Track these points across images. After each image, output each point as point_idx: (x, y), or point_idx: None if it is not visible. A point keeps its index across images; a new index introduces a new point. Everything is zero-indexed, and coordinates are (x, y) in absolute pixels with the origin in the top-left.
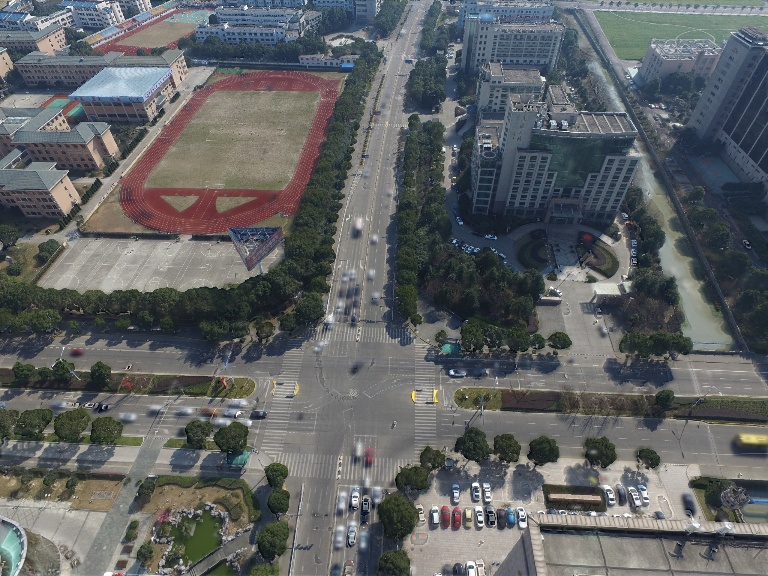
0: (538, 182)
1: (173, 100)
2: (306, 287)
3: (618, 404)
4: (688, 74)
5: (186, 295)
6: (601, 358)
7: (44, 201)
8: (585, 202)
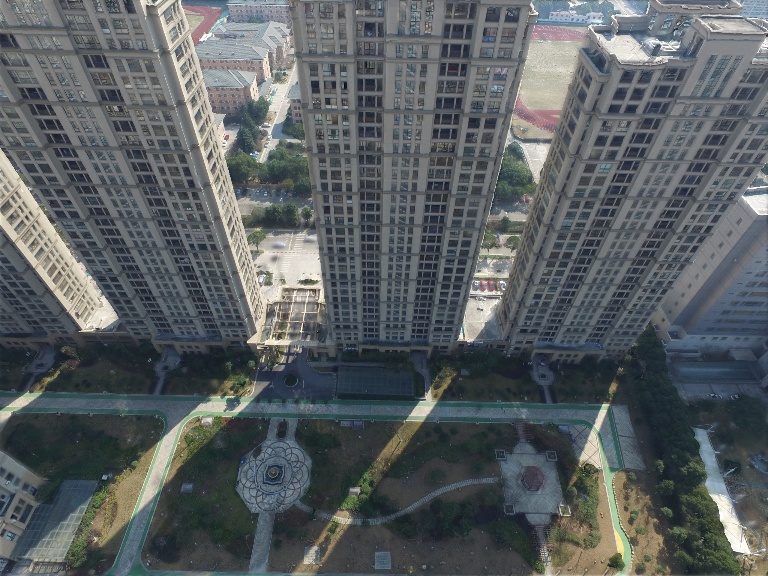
0: None
1: None
2: None
3: None
4: None
5: None
6: None
7: None
8: None
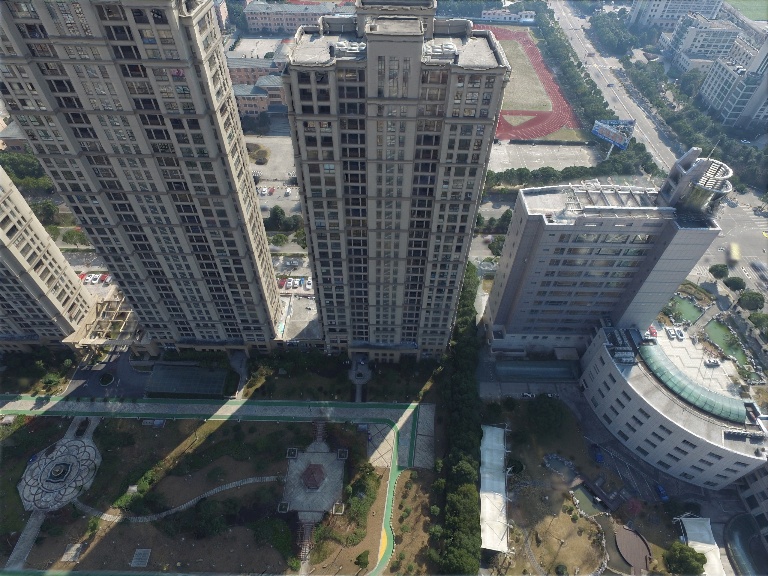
0: None
1: None
2: None
3: None
4: None
5: (572, 170)
6: None
7: None
8: None
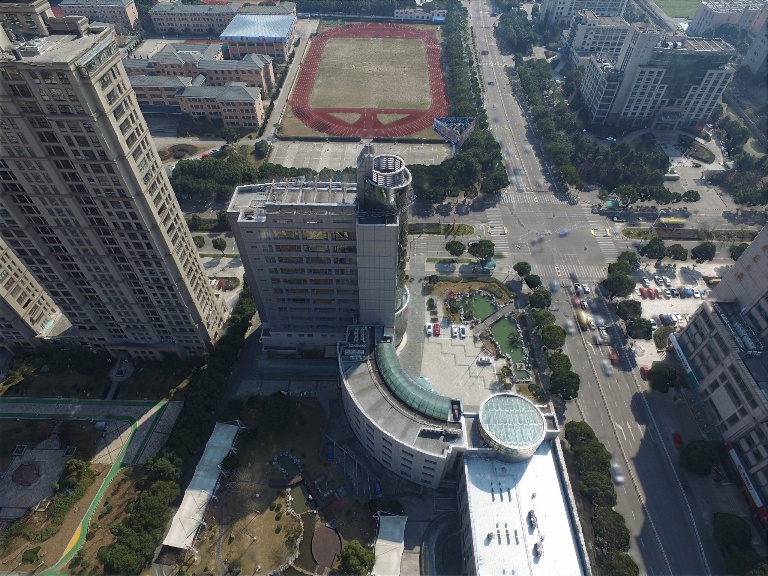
0: (650, 94)
1: (297, 44)
2: (483, 170)
3: (740, 235)
4: (736, 25)
5: (408, 168)
6: (719, 211)
7: (246, 112)
8: (684, 111)
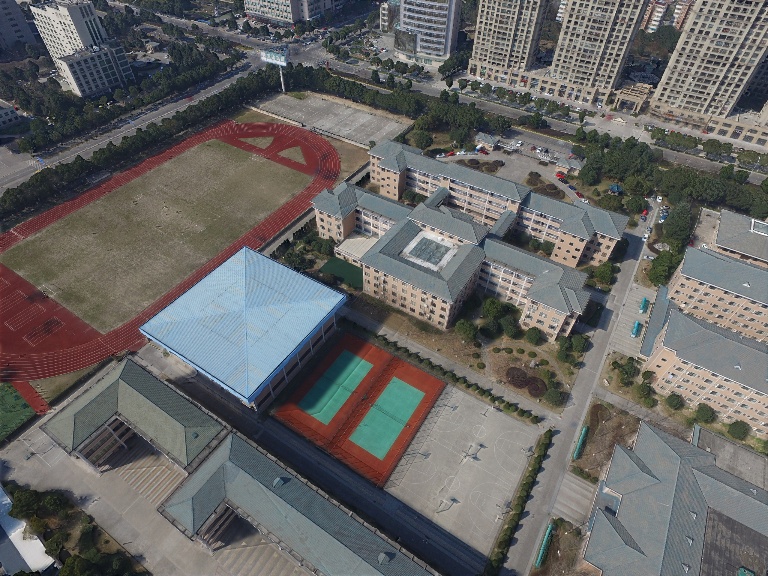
0: None
1: None
2: None
3: (207, 36)
4: None
5: (325, 72)
6: None
7: None
8: None
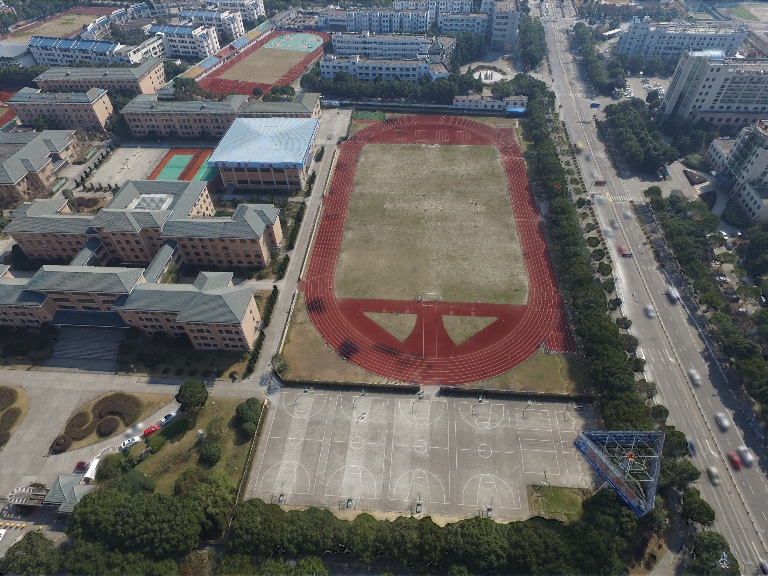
0: None
1: (320, 158)
2: None
3: None
4: None
5: (527, 544)
6: None
7: (227, 333)
8: None
